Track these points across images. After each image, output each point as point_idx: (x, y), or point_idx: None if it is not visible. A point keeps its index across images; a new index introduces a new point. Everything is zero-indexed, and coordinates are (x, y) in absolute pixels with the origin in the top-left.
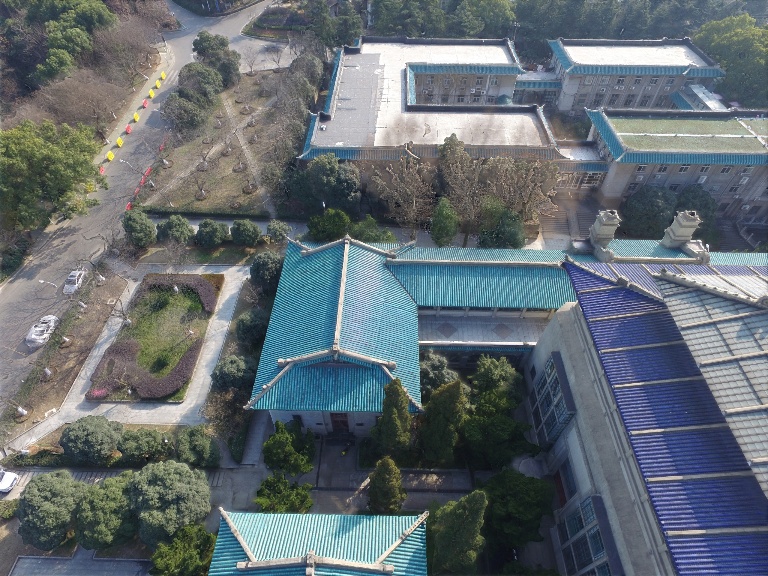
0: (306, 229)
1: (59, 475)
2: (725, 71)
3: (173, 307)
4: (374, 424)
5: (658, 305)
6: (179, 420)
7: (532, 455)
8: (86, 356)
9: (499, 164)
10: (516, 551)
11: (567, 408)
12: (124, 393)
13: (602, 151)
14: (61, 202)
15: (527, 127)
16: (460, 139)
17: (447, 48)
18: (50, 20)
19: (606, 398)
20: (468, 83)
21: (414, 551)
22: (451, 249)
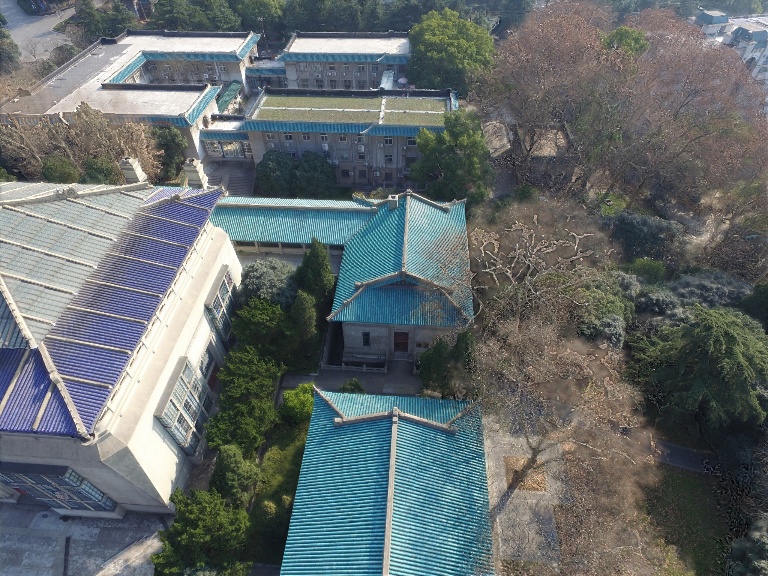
0: None
1: None
2: None
3: None
4: None
5: None
6: None
7: None
8: None
9: (124, 128)
10: None
11: None
12: None
13: None
14: None
15: (187, 101)
16: (119, 110)
17: (196, 40)
18: None
19: None
20: (200, 69)
21: None
22: None
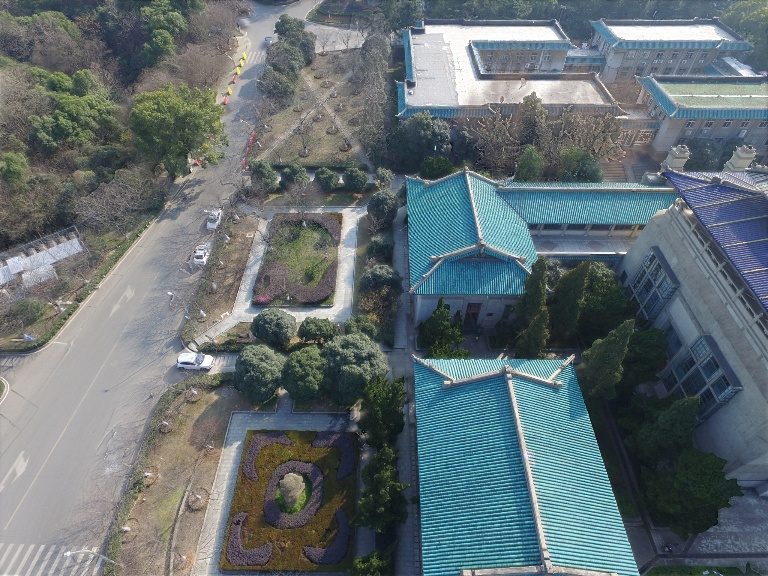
0: (401, 179)
1: (262, 347)
2: (754, 45)
3: (305, 238)
4: (501, 314)
5: (748, 194)
6: (333, 319)
7: (641, 325)
8: (241, 275)
9: (572, 118)
10: (635, 394)
11: (672, 282)
12: (283, 300)
13: (653, 111)
14: (198, 153)
15: (588, 90)
16: None
17: (501, 28)
18: (145, 6)
19: (709, 266)
20: (523, 58)
21: (570, 379)
22: (545, 183)
